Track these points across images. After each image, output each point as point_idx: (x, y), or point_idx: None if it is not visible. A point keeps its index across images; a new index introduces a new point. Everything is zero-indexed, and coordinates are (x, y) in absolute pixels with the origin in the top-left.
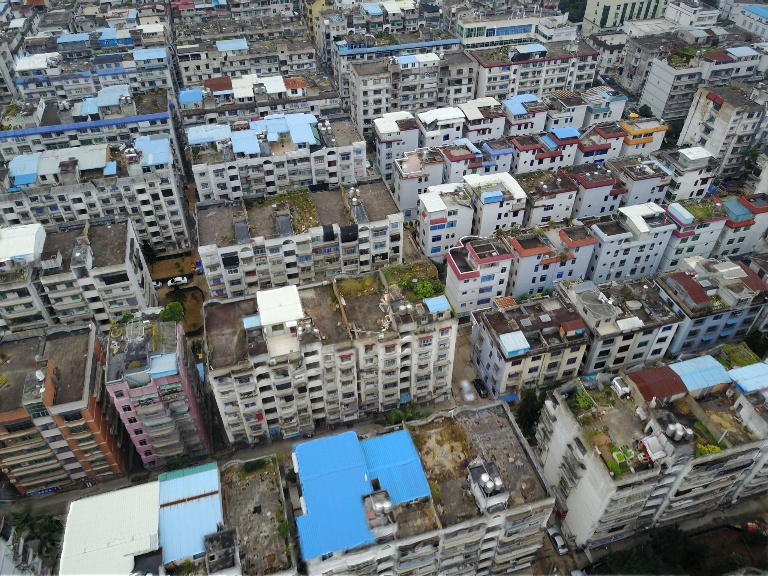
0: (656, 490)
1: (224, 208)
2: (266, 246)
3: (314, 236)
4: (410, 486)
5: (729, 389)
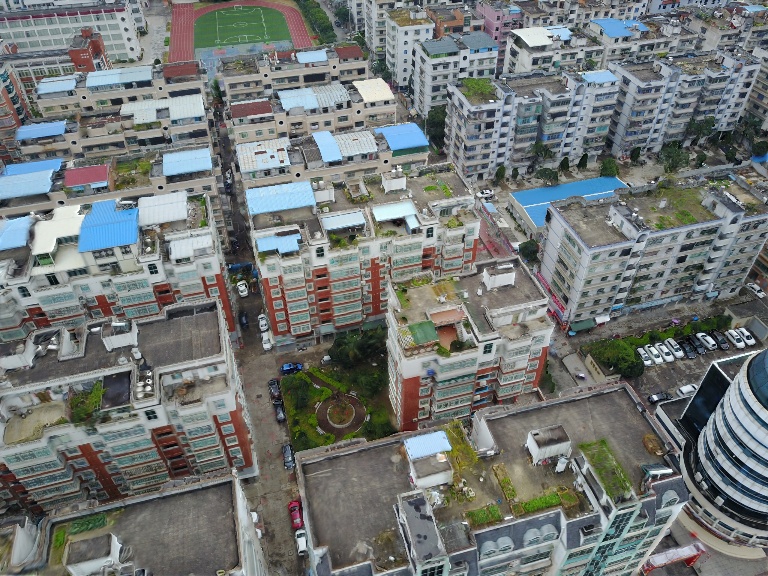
0: None
1: None
2: None
3: None
4: (641, 28)
5: (766, 12)
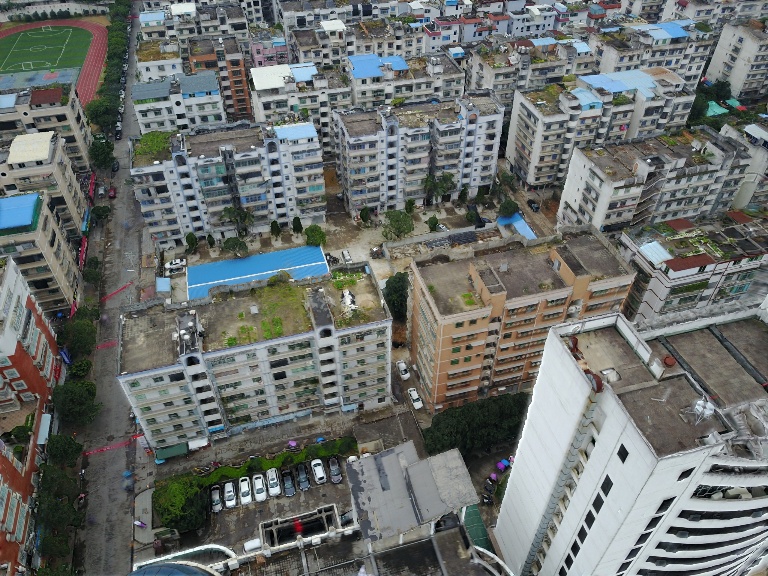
0: None
1: (294, 1)
2: (321, 14)
3: (347, 11)
4: (400, 66)
5: (555, 47)
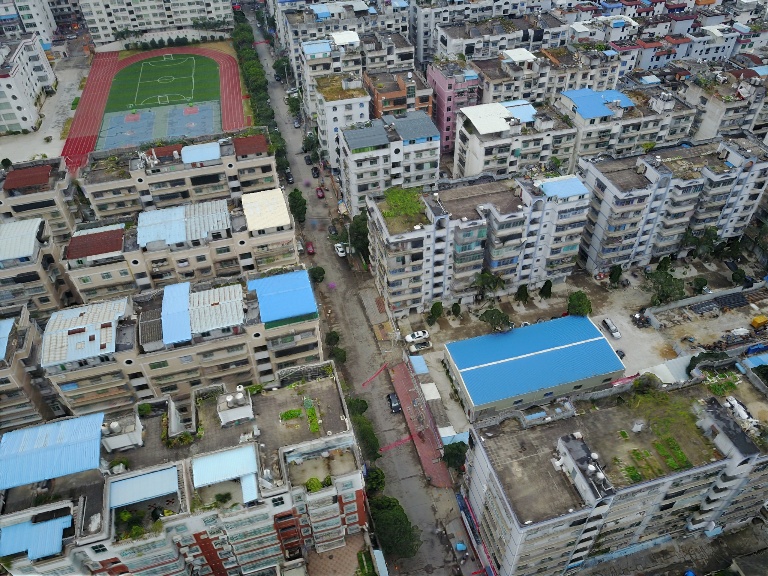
0: (743, 125)
1: (454, 27)
2: (491, 41)
3: (517, 37)
4: (624, 103)
5: None
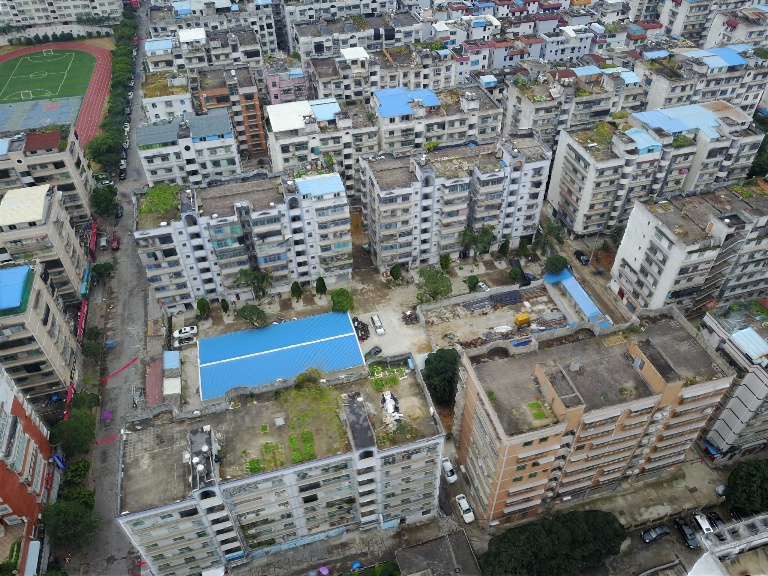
0: (559, 125)
1: (311, 25)
2: (340, 39)
3: (368, 35)
4: (431, 102)
5: (600, 76)
